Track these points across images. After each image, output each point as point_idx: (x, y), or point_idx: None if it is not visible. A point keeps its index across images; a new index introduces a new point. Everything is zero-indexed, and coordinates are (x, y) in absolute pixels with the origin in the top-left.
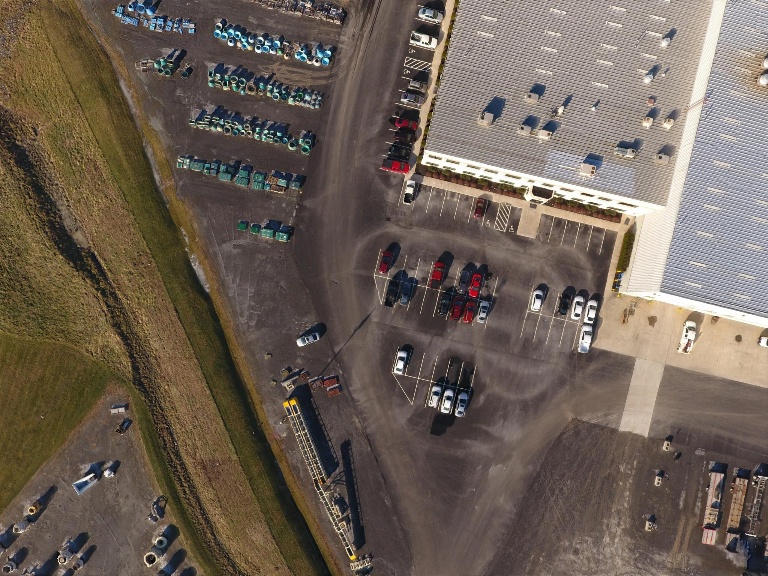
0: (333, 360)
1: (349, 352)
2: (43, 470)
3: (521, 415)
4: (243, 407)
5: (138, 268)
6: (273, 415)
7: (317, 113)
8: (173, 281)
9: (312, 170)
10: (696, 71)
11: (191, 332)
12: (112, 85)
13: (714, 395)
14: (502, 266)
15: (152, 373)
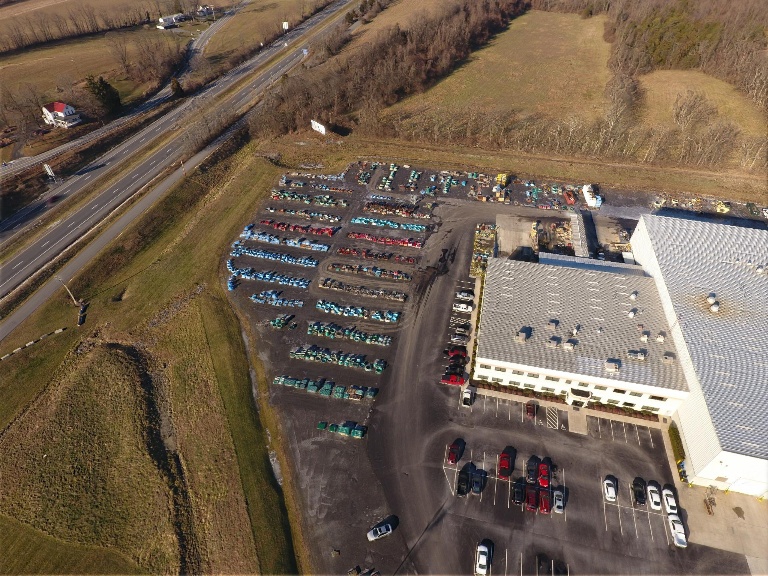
0: (407, 558)
1: (424, 548)
2: None
3: None
4: None
5: (218, 464)
6: None
7: (388, 348)
8: (250, 473)
9: (384, 384)
10: (663, 311)
11: (257, 525)
12: (236, 334)
13: None
14: (564, 459)
15: None
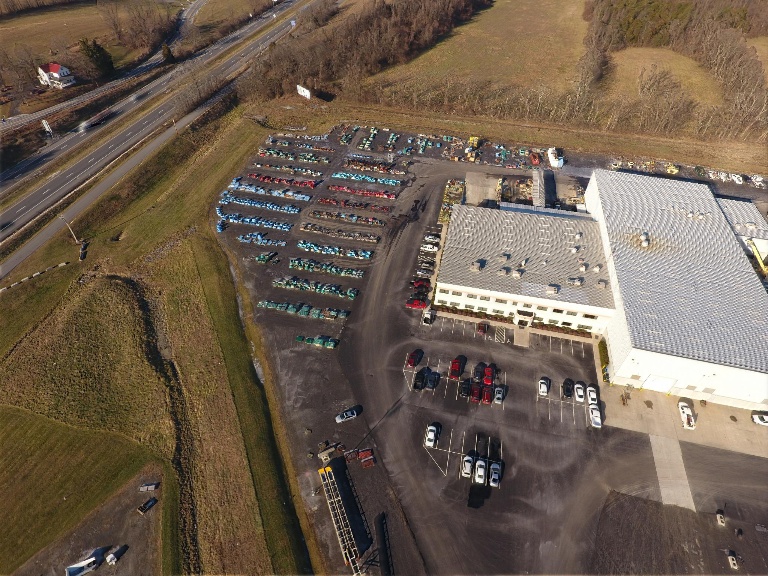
0: (368, 435)
1: (383, 428)
2: (38, 557)
3: (557, 487)
4: (277, 478)
5: (208, 368)
6: (306, 487)
7: (360, 280)
8: (236, 374)
9: (355, 308)
10: (603, 248)
11: (242, 411)
12: (225, 268)
13: (740, 468)
14: (507, 365)
15: (192, 455)
